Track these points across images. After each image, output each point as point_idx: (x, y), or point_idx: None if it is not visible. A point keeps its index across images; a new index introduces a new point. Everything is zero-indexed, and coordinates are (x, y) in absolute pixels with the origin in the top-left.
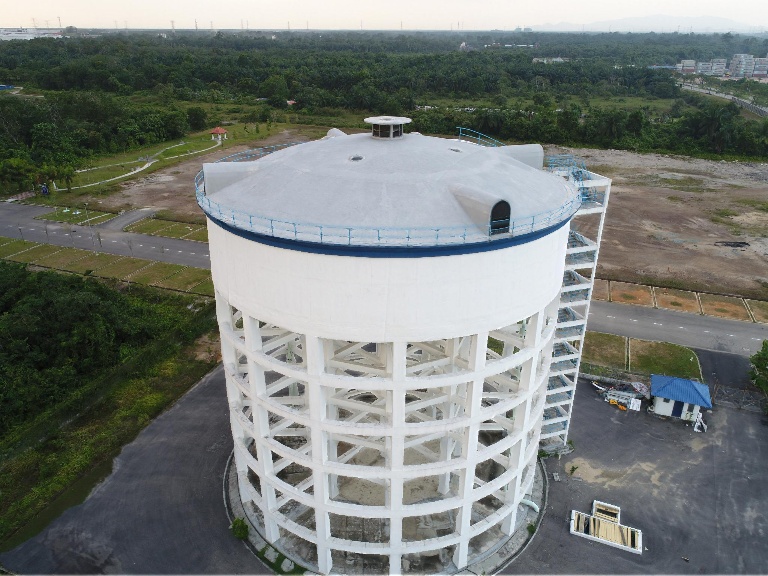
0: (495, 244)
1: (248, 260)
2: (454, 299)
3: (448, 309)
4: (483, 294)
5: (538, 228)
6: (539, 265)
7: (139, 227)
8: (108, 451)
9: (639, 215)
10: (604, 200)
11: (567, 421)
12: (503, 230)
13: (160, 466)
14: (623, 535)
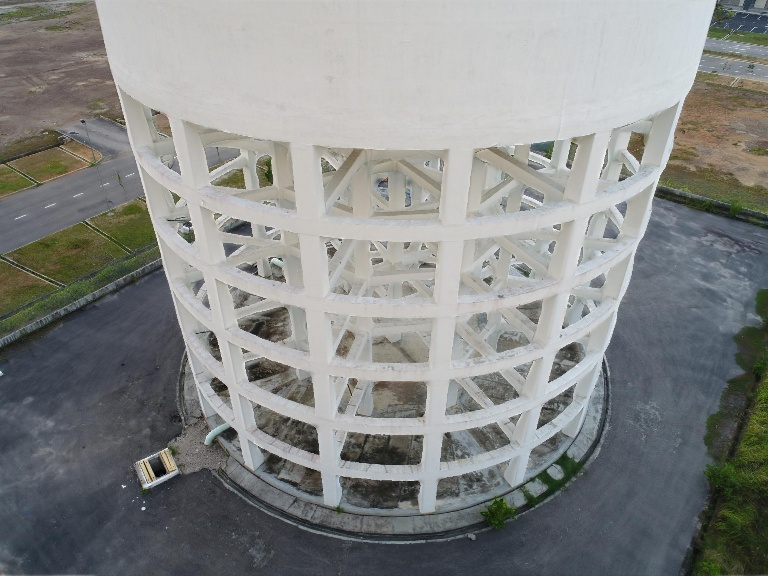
0: None
1: (647, 4)
2: None
3: None
4: None
5: None
6: None
7: None
8: None
9: (59, 51)
10: None
11: None
12: None
13: None
14: None
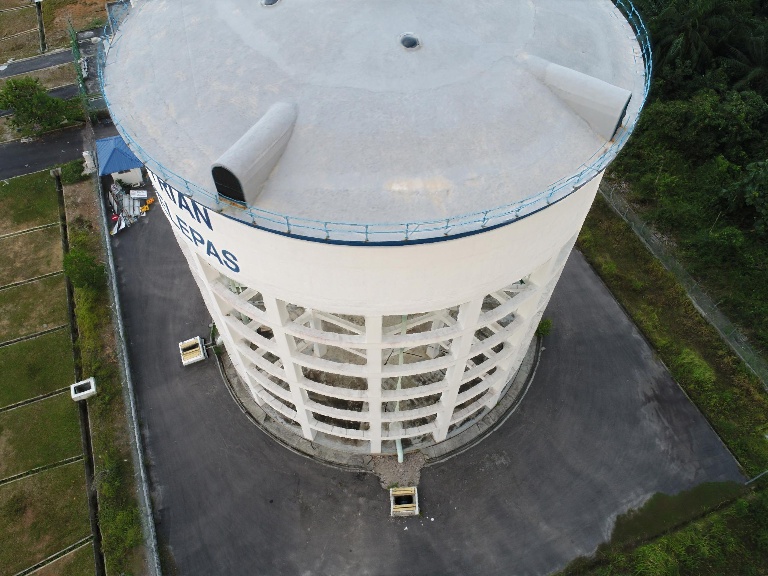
0: None
1: None
2: None
3: None
4: None
5: None
6: None
7: None
8: (614, 555)
9: None
10: None
11: None
12: None
13: (566, 480)
14: None
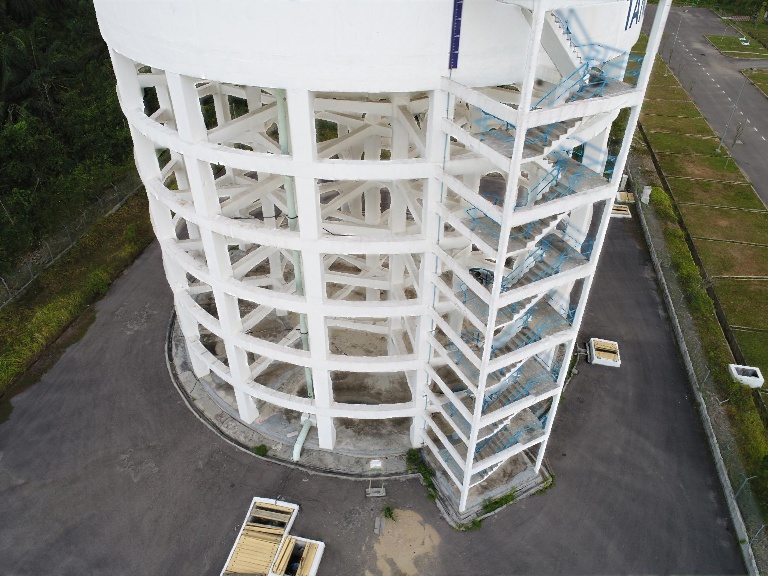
0: None
1: None
2: None
3: None
4: None
5: None
6: None
7: (762, 74)
8: None
9: None
10: None
11: None
12: None
13: None
14: (244, 575)
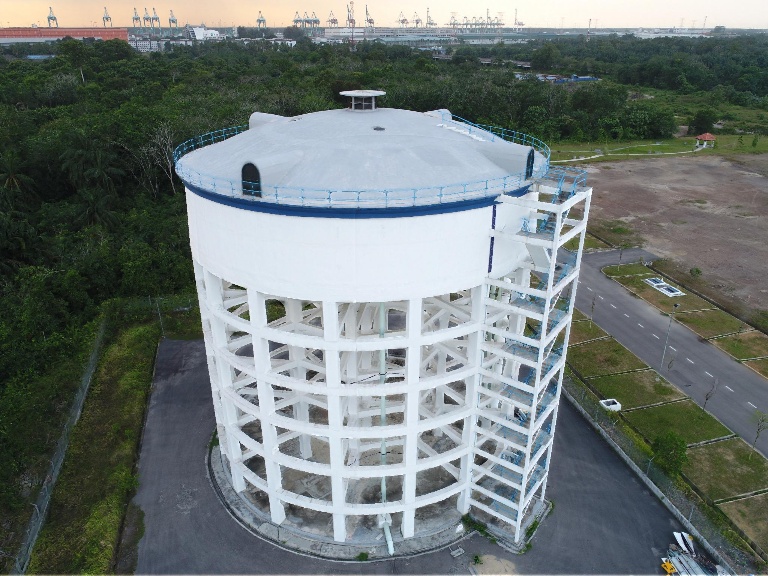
0: (243, 203)
1: None
2: (225, 245)
3: (223, 252)
4: (245, 250)
5: (289, 203)
6: (312, 248)
7: None
8: None
9: None
10: (554, 233)
11: (518, 512)
12: (255, 193)
13: None
14: None
